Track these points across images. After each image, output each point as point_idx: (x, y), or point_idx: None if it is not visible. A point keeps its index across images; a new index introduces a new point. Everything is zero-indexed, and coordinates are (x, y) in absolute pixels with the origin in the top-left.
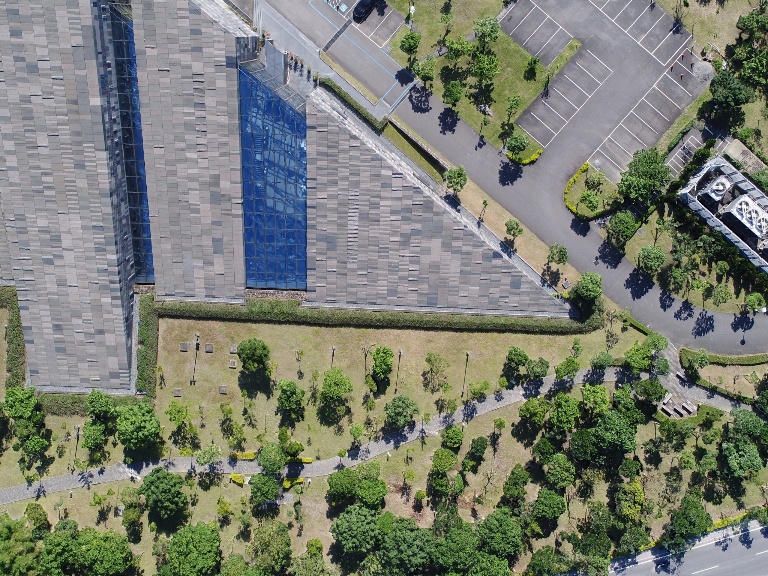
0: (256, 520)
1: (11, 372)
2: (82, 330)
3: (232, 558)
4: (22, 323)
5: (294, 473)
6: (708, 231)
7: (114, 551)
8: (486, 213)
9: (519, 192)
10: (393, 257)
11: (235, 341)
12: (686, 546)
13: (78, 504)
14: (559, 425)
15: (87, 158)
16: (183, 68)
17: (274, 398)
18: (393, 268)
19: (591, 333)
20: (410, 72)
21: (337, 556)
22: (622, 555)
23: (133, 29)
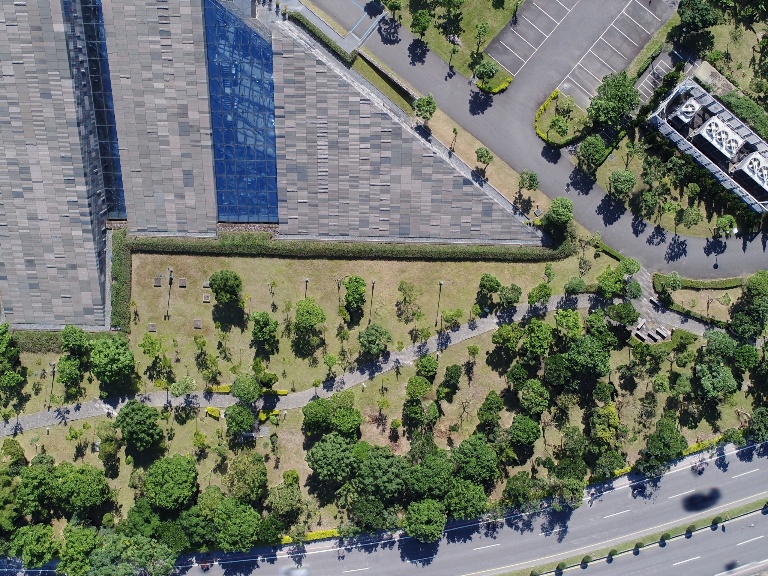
0: (233, 453)
1: None
2: (54, 265)
3: (209, 489)
4: None
5: (270, 405)
6: (679, 156)
7: (90, 483)
8: (457, 143)
9: (489, 121)
10: (364, 186)
11: (208, 275)
12: (661, 468)
13: (55, 441)
14: (532, 350)
15: (53, 87)
16: None
17: (248, 331)
18: (364, 198)
19: (564, 260)
20: (379, 4)
21: (314, 487)
22: (598, 480)
23: None
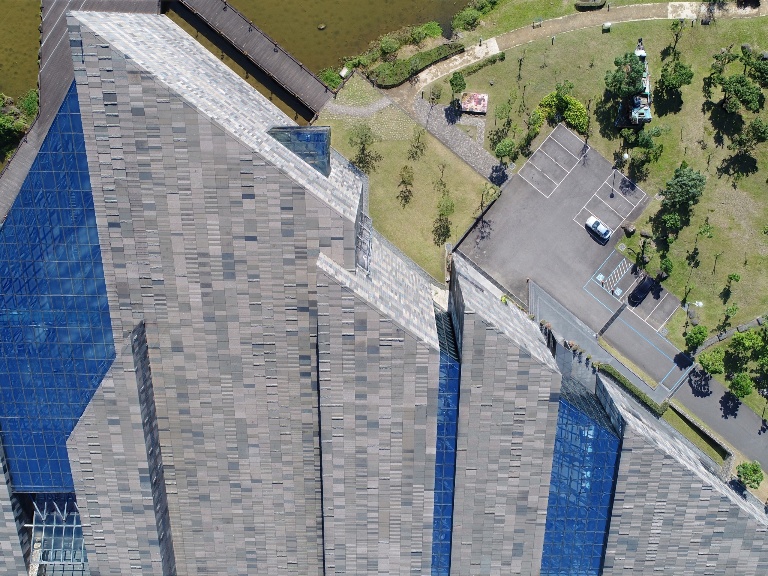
0: None
1: None
2: None
3: None
4: None
5: None
6: None
7: None
8: None
9: None
10: (692, 555)
11: None
12: None
13: None
14: None
15: (415, 497)
16: (506, 403)
17: None
18: (690, 564)
19: None
20: (688, 356)
21: None
22: None
23: (461, 372)
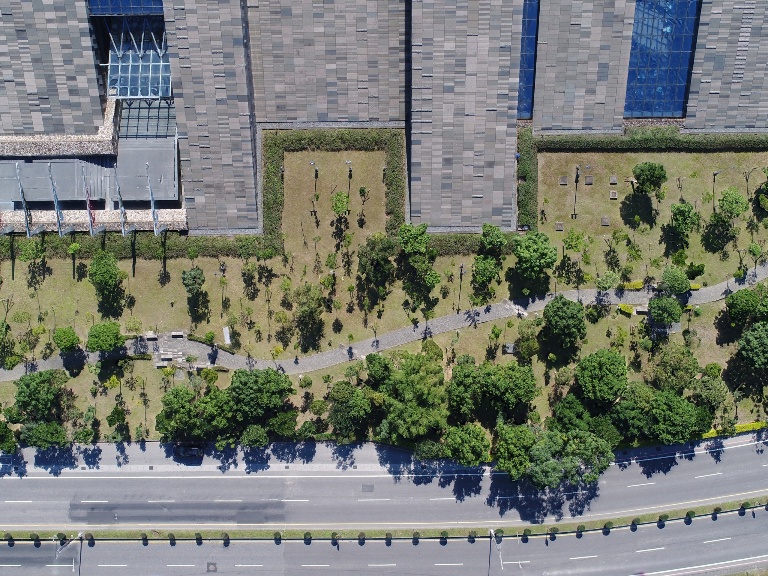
0: None
1: (392, 214)
2: (472, 163)
3: (634, 384)
4: (412, 159)
5: (682, 301)
6: None
7: (525, 379)
8: None
9: None
10: None
11: (614, 172)
12: None
13: (465, 344)
14: None
15: None
16: None
17: (657, 227)
18: None
19: None
20: None
21: (729, 382)
22: None
23: None
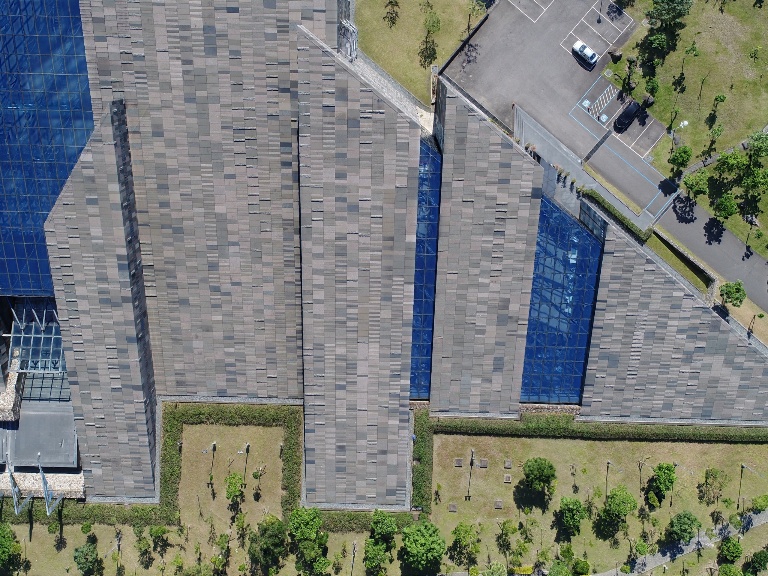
0: None
1: (288, 490)
2: (365, 451)
3: None
4: (306, 445)
5: None
6: None
7: None
8: (755, 324)
9: None
10: (673, 373)
11: (509, 456)
12: None
13: None
14: None
15: (395, 291)
16: (487, 199)
17: (549, 512)
18: (672, 383)
19: None
20: (673, 182)
21: None
22: None
23: (442, 163)
